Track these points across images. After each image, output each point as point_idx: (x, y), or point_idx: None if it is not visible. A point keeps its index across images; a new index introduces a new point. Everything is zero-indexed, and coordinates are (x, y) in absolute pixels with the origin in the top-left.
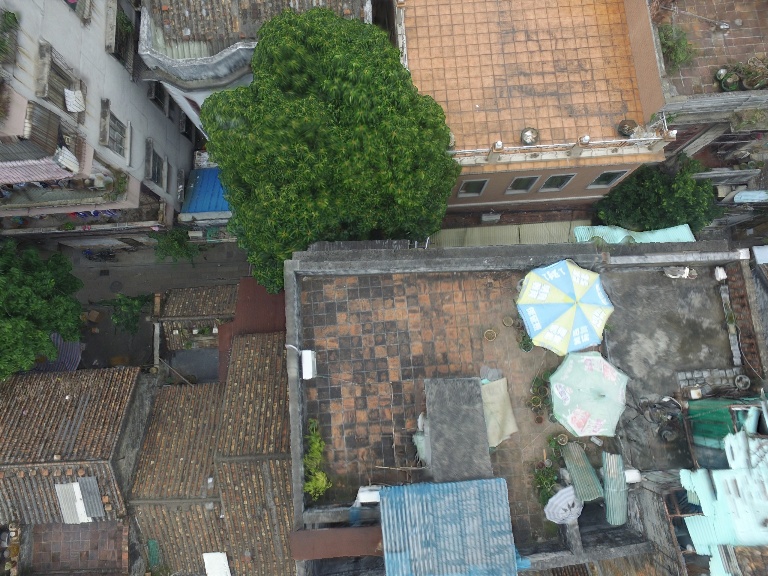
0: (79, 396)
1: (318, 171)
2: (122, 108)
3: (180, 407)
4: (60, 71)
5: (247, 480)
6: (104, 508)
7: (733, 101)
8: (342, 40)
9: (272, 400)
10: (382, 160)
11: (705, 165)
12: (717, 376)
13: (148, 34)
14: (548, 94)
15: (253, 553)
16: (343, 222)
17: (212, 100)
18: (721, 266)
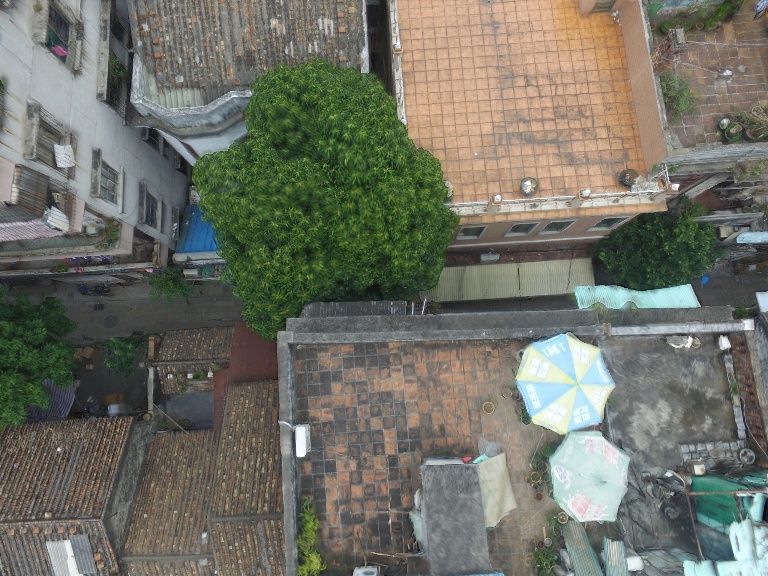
0: (71, 448)
1: (313, 234)
2: (114, 154)
3: (174, 455)
4: (49, 127)
5: (241, 539)
6: (96, 565)
7: (736, 153)
8: (337, 97)
9: (267, 455)
10: (378, 222)
11: (707, 206)
12: (721, 449)
13: (140, 82)
14: (548, 142)
15: None
16: (339, 280)
17: (204, 162)
18: (725, 335)
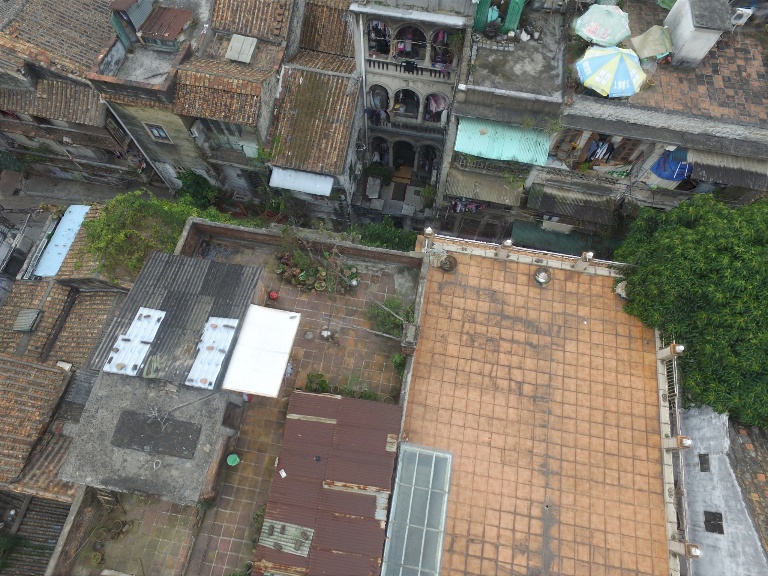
0: None
1: None
2: None
3: None
4: None
5: None
6: None
7: None
8: None
9: None
10: None
11: None
12: (488, 45)
13: None
14: (512, 318)
15: None
16: None
17: None
18: None
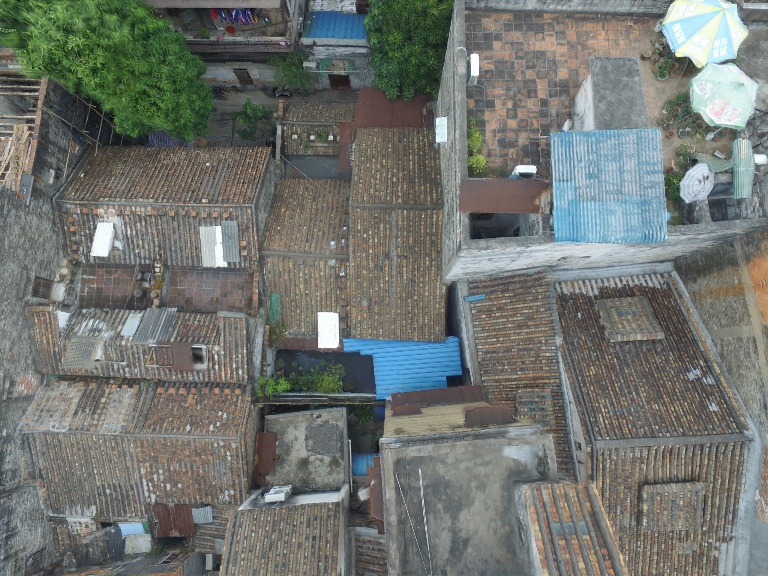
0: (218, 164)
1: None
2: None
3: (300, 193)
4: None
5: (375, 229)
6: (240, 254)
7: None
8: None
9: (397, 170)
10: None
11: None
12: None
13: None
14: None
15: (370, 303)
16: None
17: None
18: None
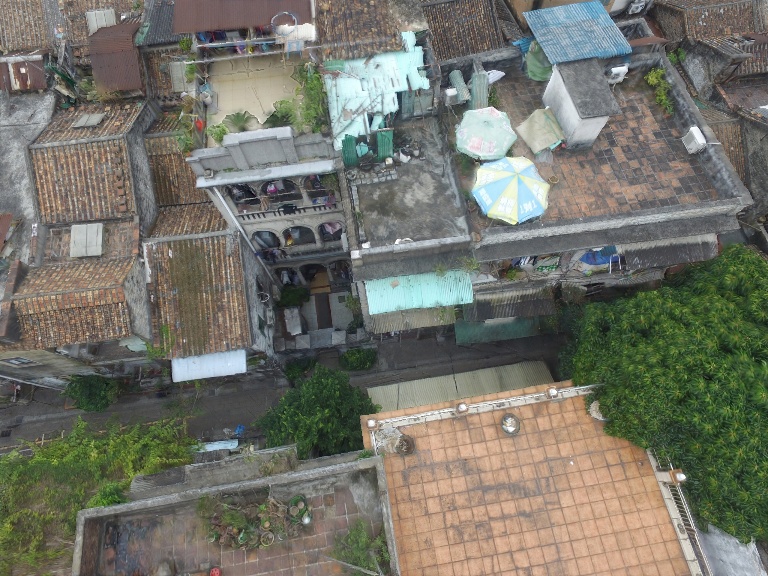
0: None
1: None
2: None
3: None
4: None
5: None
6: None
7: None
8: None
9: None
10: (695, 318)
11: None
12: (368, 179)
13: None
14: (494, 487)
15: None
16: None
17: None
18: None
